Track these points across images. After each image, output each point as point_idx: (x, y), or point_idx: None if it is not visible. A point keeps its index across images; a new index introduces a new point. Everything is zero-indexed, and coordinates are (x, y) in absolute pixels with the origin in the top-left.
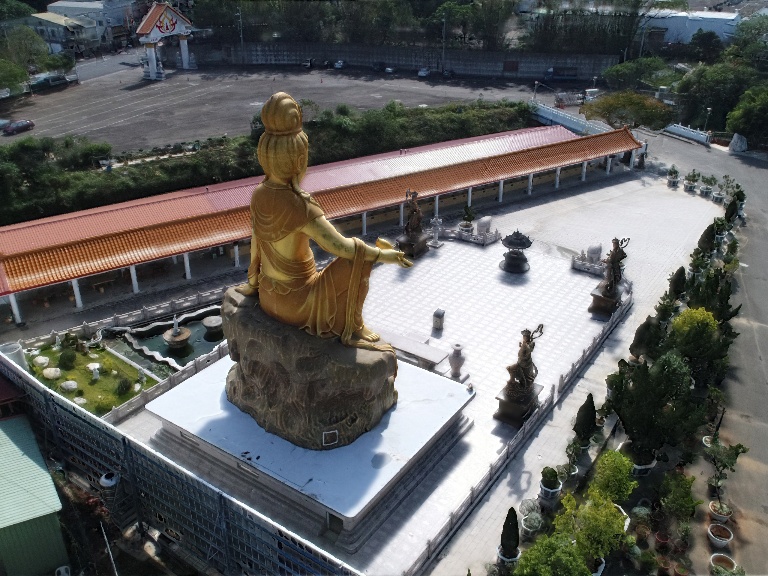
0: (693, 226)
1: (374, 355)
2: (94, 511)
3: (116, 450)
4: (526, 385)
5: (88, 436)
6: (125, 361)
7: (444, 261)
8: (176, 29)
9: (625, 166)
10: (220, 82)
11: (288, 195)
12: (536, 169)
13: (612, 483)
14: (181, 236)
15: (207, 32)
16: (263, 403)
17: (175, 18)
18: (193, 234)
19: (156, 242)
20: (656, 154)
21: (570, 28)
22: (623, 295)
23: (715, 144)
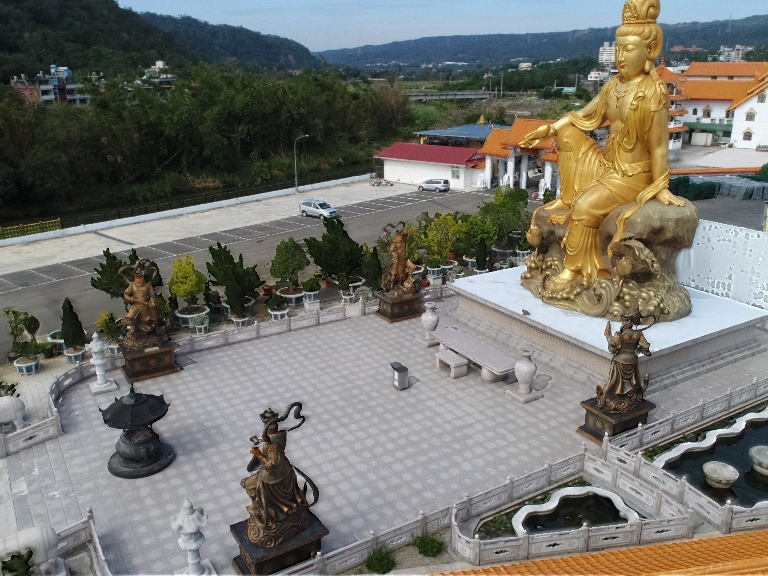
0: None
1: None
2: None
3: None
4: None
5: None
6: None
7: None
8: None
9: None
10: None
11: None
12: None
13: None
14: None
15: None
16: None
17: None
18: None
19: None
20: None
21: None
22: (96, 379)
23: None
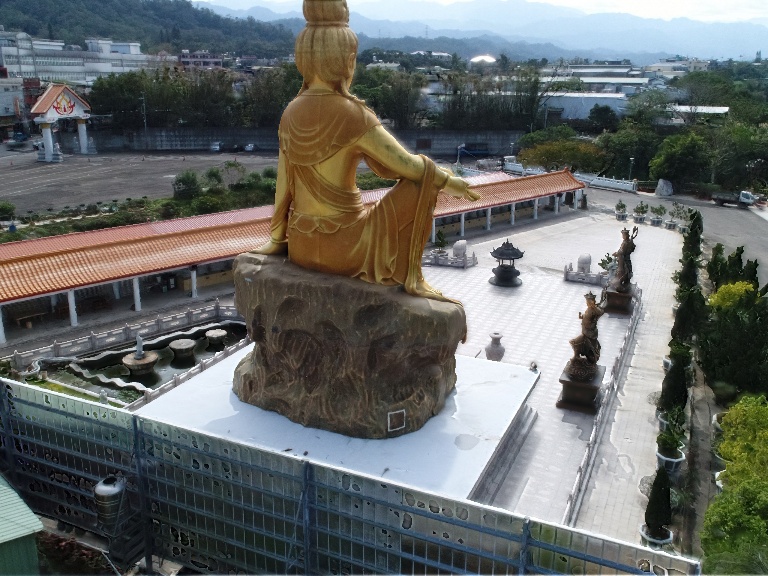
0: (660, 246)
1: (448, 305)
2: (69, 557)
3: (116, 446)
4: (595, 360)
5: (67, 437)
6: (76, 390)
7: (428, 282)
8: (74, 112)
9: (569, 208)
10: (125, 162)
11: (338, 100)
12: (495, 202)
13: (760, 432)
14: (130, 258)
15: (107, 118)
16: (298, 389)
17: (73, 101)
18: (144, 256)
19: (100, 264)
20: (592, 200)
21: (477, 107)
22: None
23: (641, 192)
